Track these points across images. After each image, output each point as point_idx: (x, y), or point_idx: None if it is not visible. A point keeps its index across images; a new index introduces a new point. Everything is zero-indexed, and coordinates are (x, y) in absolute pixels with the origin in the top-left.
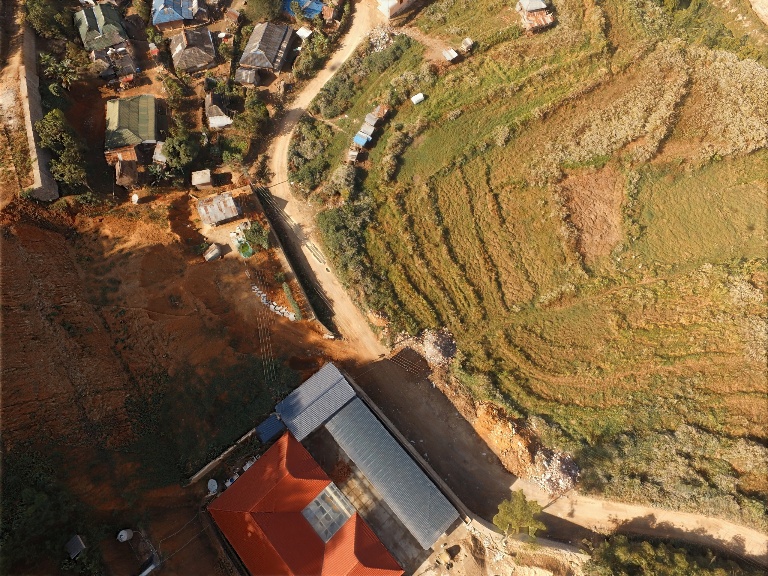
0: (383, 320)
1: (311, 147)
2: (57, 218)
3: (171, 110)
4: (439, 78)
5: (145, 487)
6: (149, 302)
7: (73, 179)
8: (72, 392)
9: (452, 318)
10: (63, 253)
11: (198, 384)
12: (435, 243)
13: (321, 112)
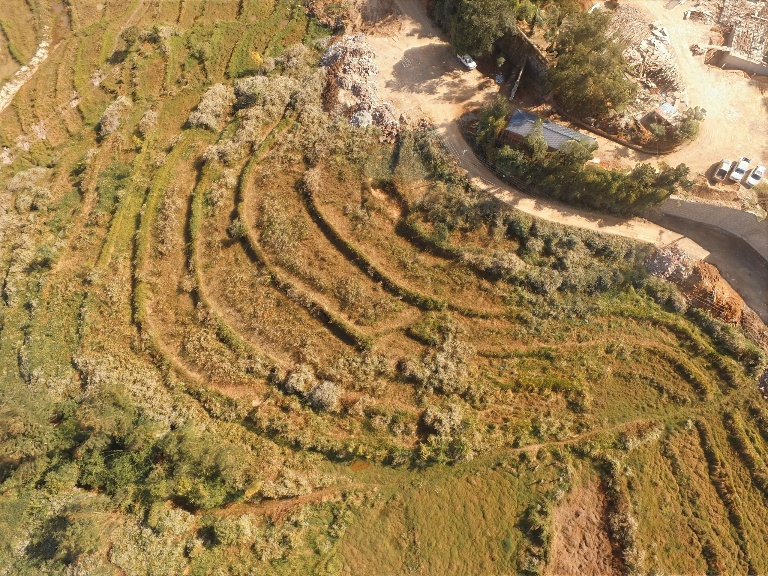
0: None
1: None
2: None
3: None
4: None
5: None
6: None
7: None
8: None
9: None
10: None
11: None
12: None
13: None
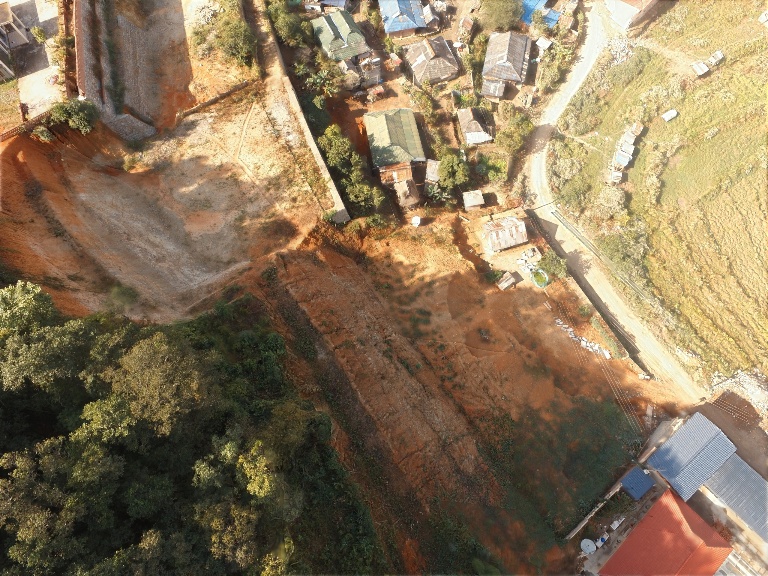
0: (697, 360)
1: (570, 166)
2: (349, 242)
3: (427, 125)
4: (687, 93)
5: (541, 550)
6: (465, 336)
7: (379, 202)
8: (436, 439)
9: (764, 358)
10: (362, 280)
11: (548, 431)
12: (721, 274)
13: (570, 128)
